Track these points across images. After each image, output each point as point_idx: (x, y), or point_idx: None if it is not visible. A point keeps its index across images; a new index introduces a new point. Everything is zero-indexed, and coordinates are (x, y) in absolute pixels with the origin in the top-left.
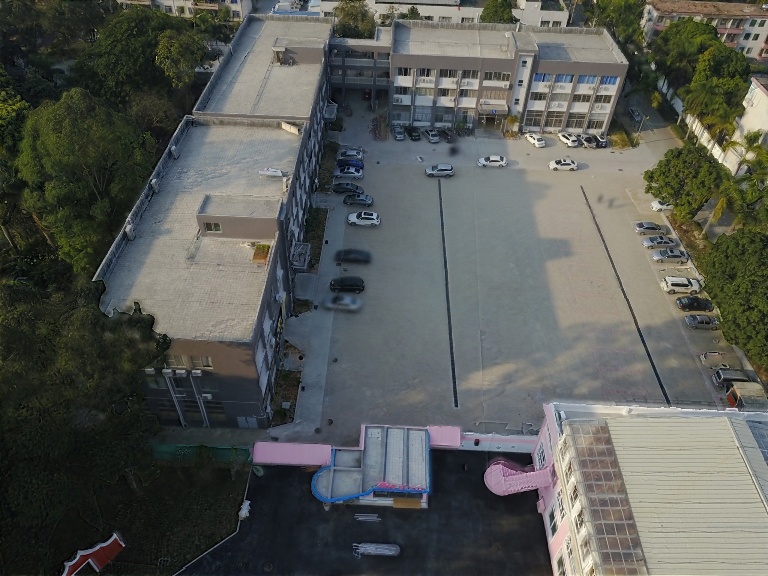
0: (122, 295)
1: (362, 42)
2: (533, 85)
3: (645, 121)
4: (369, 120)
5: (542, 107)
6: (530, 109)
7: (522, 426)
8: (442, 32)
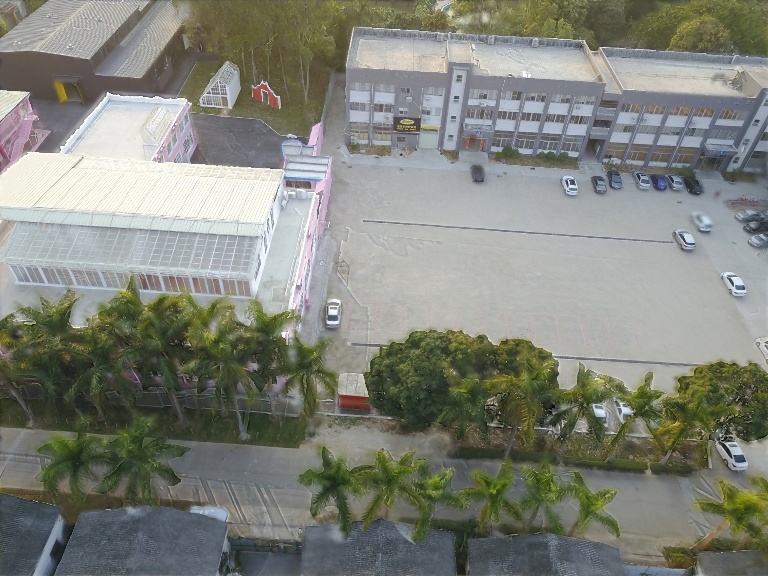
0: (390, 43)
1: None
2: None
3: None
4: (764, 198)
5: None
6: None
7: None
8: None
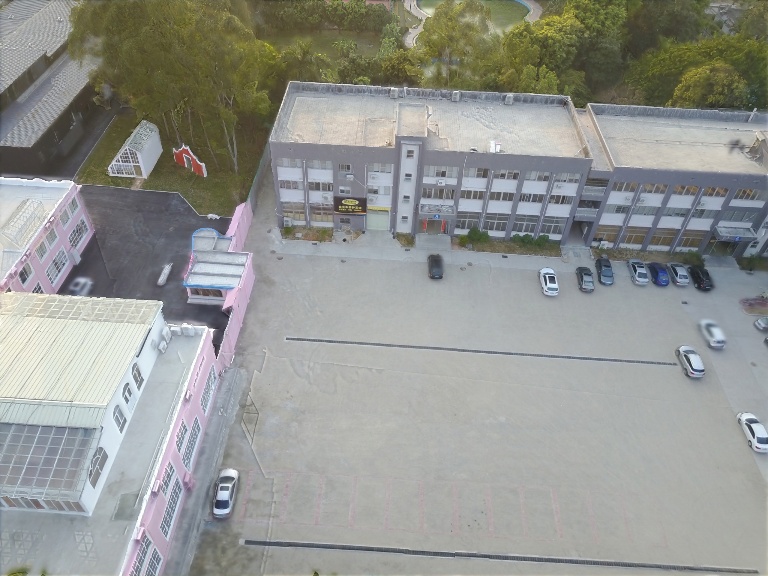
0: (332, 101)
1: None
2: None
3: None
4: None
5: None
6: None
7: (230, 353)
8: None
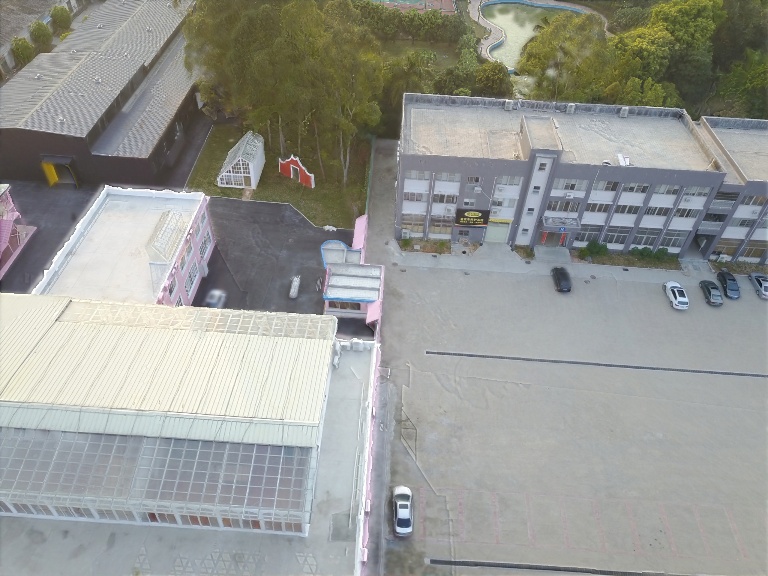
0: (448, 113)
1: None
2: None
3: None
4: None
5: None
6: None
7: None
8: None
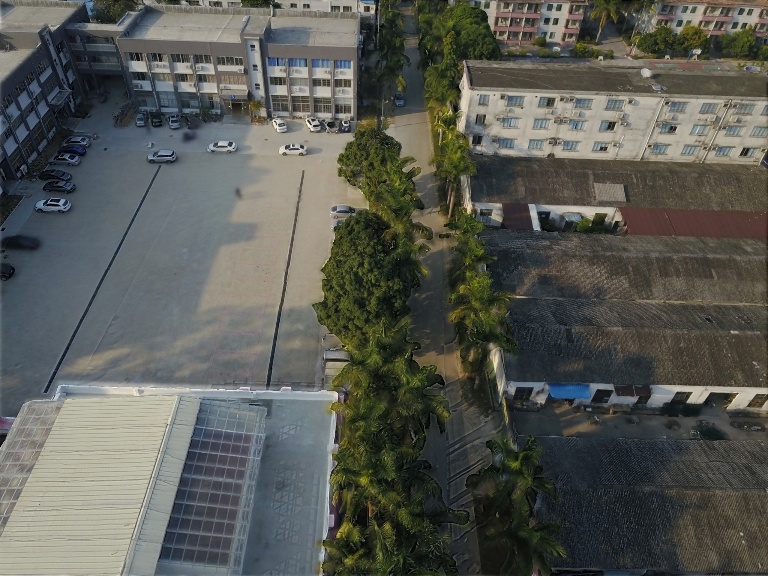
0: None
1: (102, 27)
2: (269, 69)
3: (383, 105)
4: (119, 107)
5: (285, 92)
6: (273, 94)
7: None
8: (194, 17)
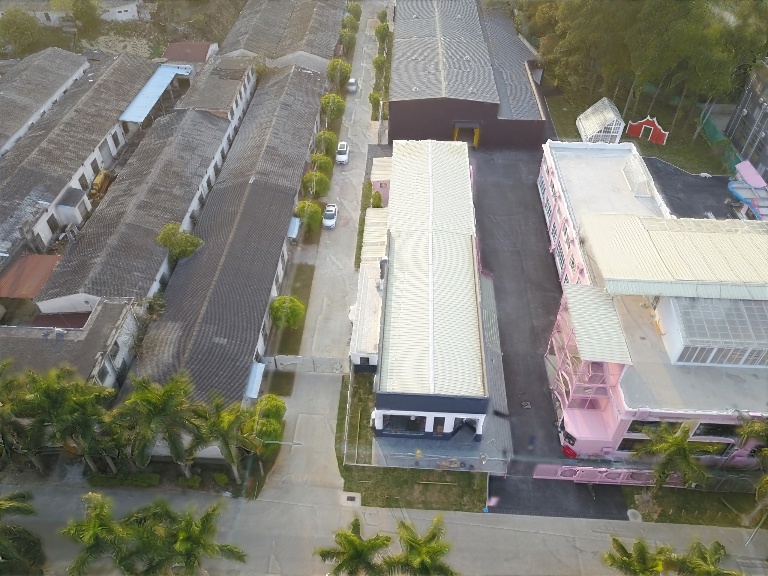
0: None
1: None
2: None
3: None
4: None
5: None
6: None
7: None
8: None
